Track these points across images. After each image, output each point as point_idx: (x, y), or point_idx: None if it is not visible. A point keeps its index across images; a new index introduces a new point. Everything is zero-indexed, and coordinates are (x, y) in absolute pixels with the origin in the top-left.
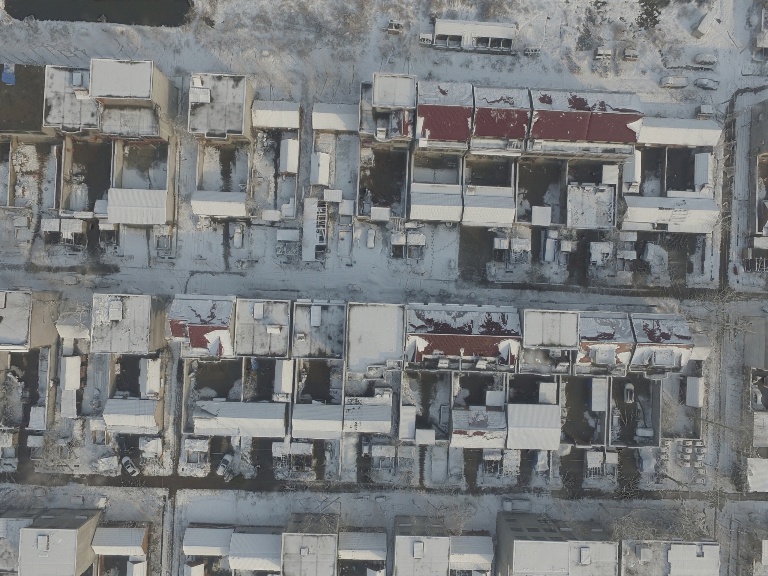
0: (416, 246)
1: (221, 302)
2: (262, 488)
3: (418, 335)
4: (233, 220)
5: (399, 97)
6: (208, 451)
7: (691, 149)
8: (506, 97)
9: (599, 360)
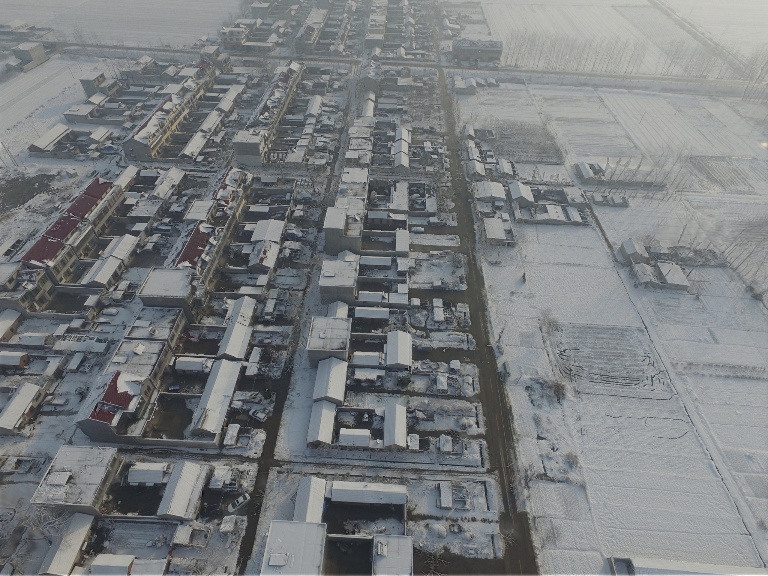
0: (129, 287)
1: (97, 384)
2: (286, 388)
3: (178, 264)
4: (40, 407)
5: (8, 271)
6: (241, 427)
7: (138, 179)
8: (48, 225)
9: (227, 195)
